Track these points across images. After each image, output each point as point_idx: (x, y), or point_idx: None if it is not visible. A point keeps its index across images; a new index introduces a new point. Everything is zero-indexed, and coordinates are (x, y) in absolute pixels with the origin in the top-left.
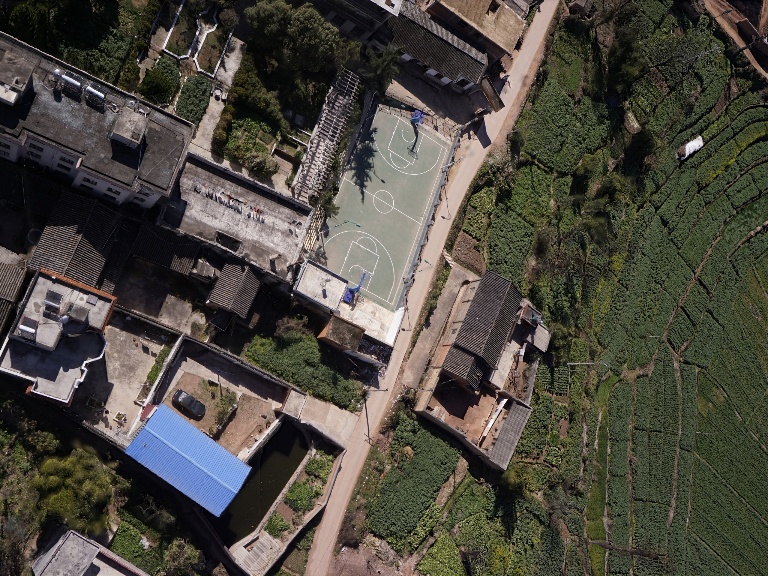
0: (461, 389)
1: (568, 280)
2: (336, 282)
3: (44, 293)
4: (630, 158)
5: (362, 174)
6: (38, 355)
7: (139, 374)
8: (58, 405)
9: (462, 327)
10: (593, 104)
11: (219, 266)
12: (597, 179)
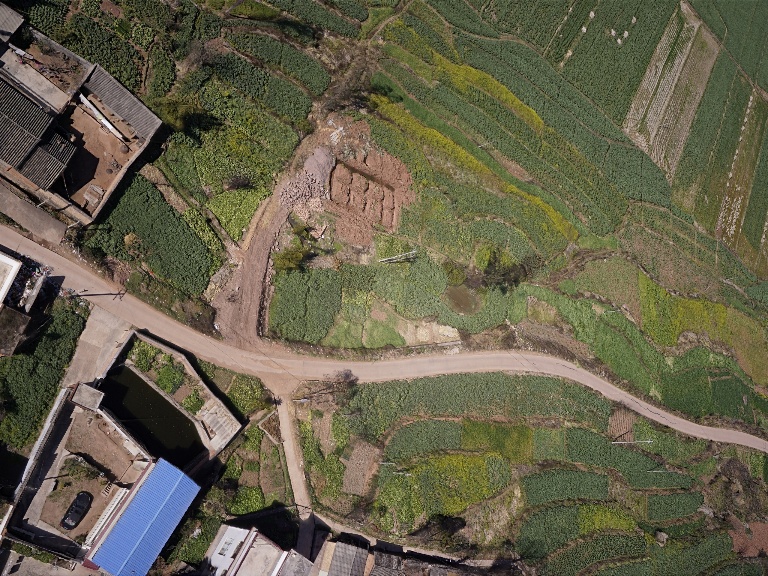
0: None
1: None
2: None
3: None
4: None
5: None
6: None
7: (42, 571)
8: None
9: None
10: None
11: None
12: None
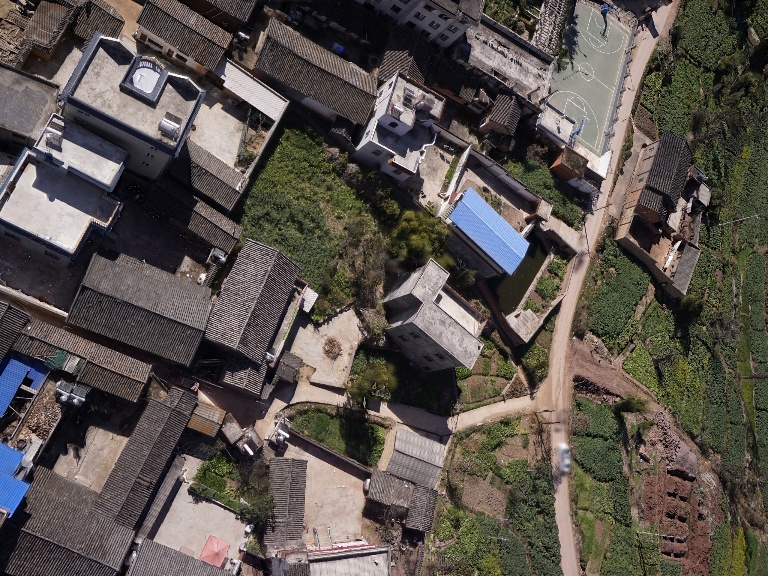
0: (647, 229)
1: (715, 158)
2: (566, 122)
3: (402, 89)
4: (753, 66)
5: (570, 49)
6: (393, 138)
7: (439, 175)
8: (397, 184)
9: (651, 173)
10: (725, 17)
11: (491, 98)
12: (730, 79)
